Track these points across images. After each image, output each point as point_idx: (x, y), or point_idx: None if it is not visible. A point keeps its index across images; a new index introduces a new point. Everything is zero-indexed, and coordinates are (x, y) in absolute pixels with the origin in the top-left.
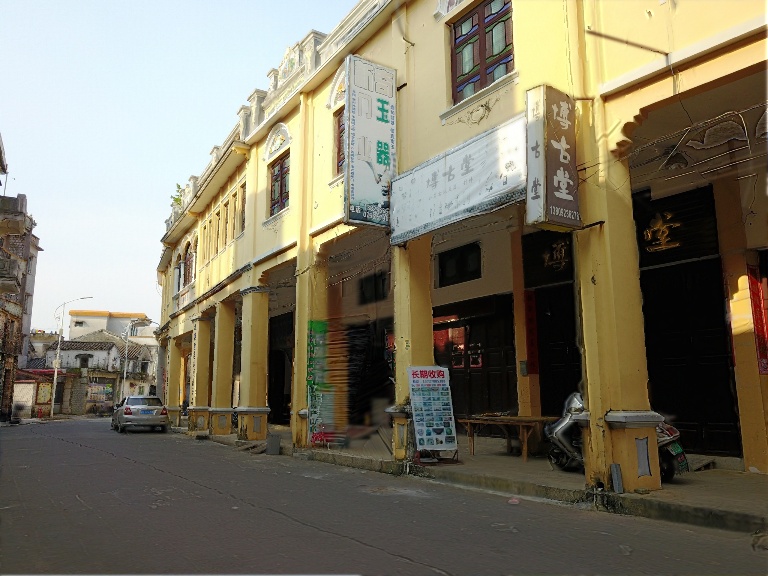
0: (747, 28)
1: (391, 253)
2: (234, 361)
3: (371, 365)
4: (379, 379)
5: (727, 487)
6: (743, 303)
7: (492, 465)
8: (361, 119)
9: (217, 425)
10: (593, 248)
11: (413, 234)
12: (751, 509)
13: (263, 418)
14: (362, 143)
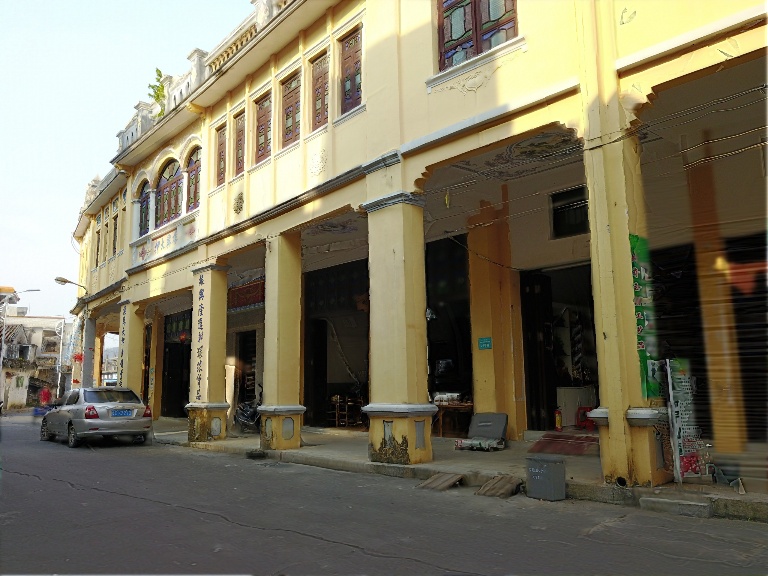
0: None
1: None
2: None
3: None
4: None
5: None
6: None
7: None
8: None
9: (280, 433)
10: None
11: None
12: None
13: (427, 423)
14: None
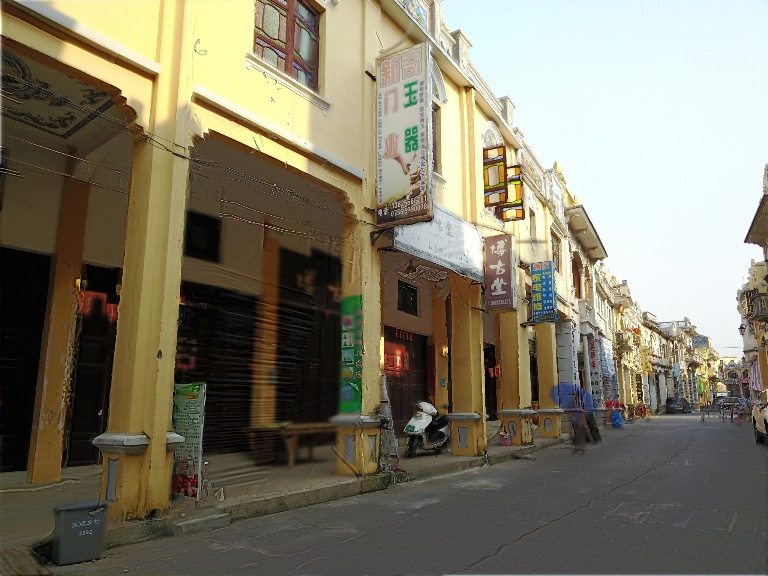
0: None
1: (355, 241)
2: None
3: (319, 364)
4: (334, 383)
5: None
6: (382, 352)
7: None
8: None
9: None
10: None
11: (416, 252)
12: None
13: None
14: None
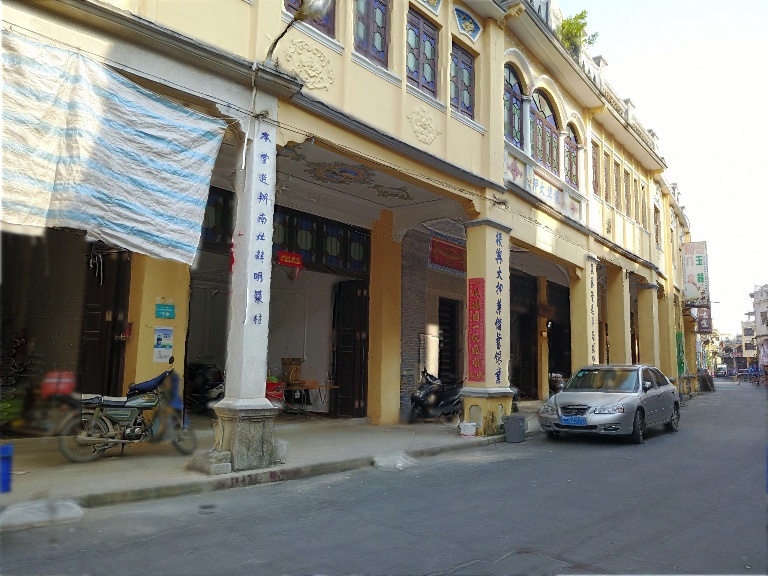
0: None
1: None
2: (419, 296)
3: None
4: None
5: None
6: None
7: None
8: None
9: None
10: None
11: None
12: None
13: None
14: None
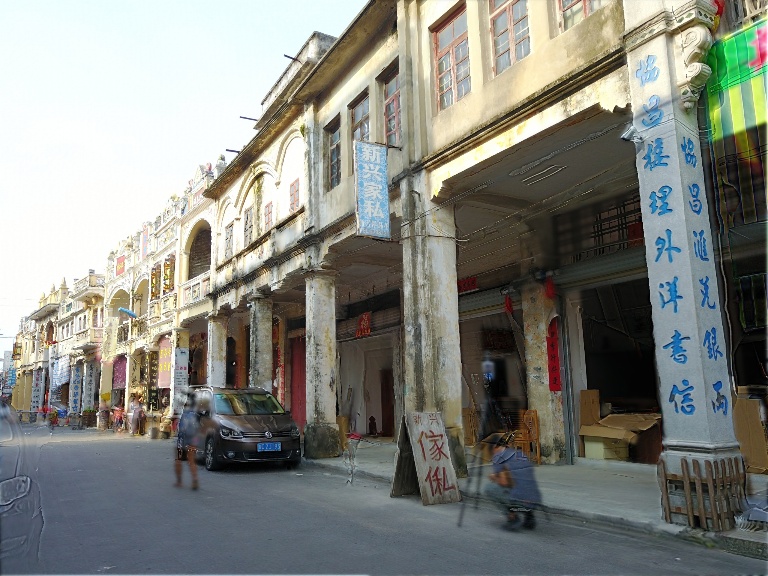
0: None
1: None
2: None
3: None
4: None
5: None
6: None
7: None
8: (6, 362)
9: None
10: (13, 391)
11: None
12: None
13: None
14: (6, 366)
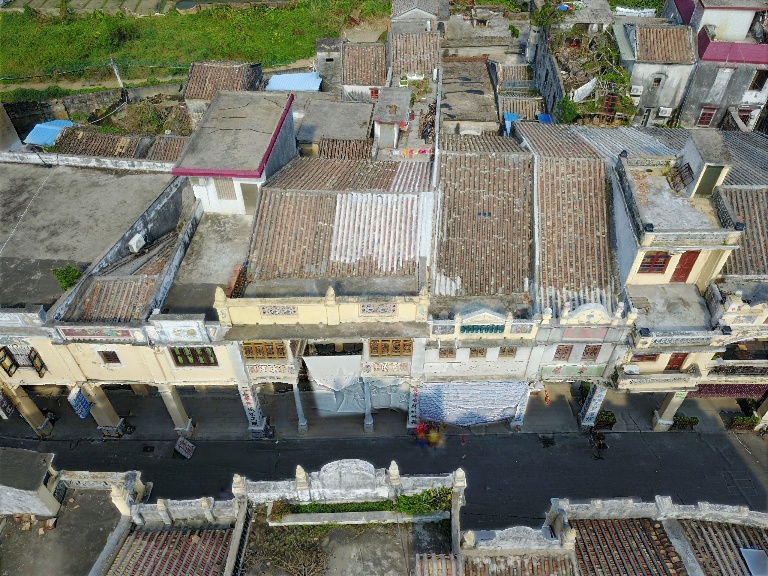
0: (40, 382)
1: None
2: None
3: None
4: None
5: (66, 415)
6: None
7: (5, 419)
8: None
9: None
10: None
11: None
12: (70, 434)
13: None
14: None
